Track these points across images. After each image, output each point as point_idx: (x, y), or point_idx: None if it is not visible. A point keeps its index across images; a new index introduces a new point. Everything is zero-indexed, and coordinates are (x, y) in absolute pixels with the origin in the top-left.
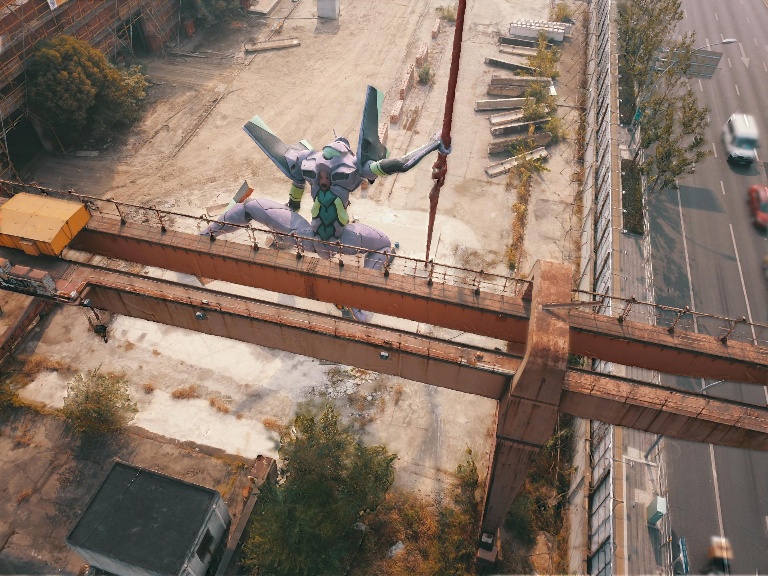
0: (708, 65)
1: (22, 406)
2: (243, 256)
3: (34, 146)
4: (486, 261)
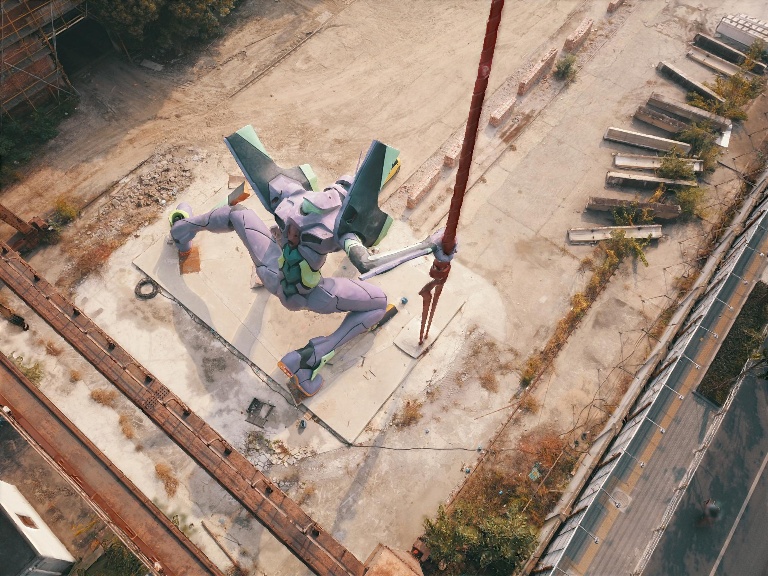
0: None
1: None
2: (93, 351)
3: (108, 40)
4: (499, 361)
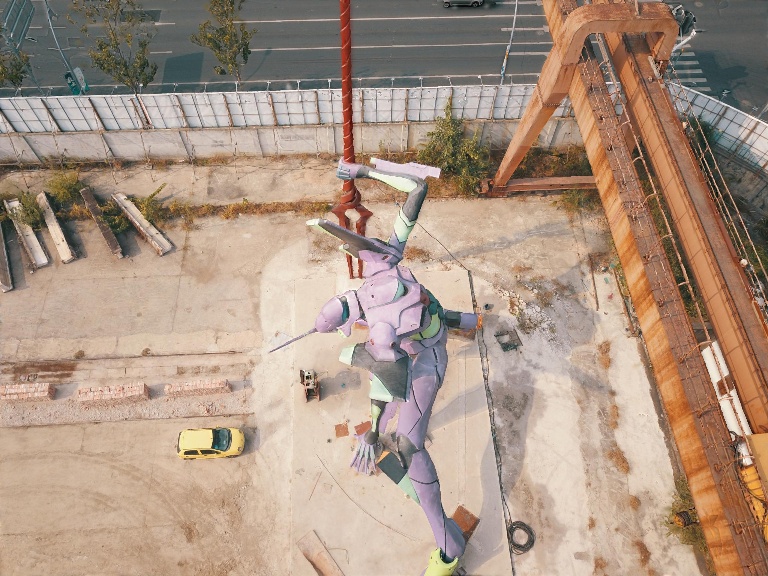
0: (25, 1)
1: None
2: None
3: None
4: None
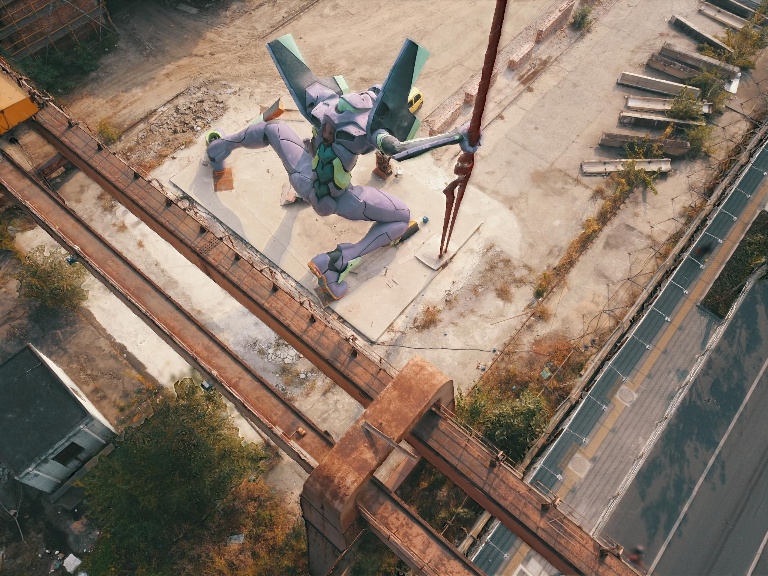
0: None
1: (10, 250)
2: (152, 207)
3: None
4: (514, 275)
